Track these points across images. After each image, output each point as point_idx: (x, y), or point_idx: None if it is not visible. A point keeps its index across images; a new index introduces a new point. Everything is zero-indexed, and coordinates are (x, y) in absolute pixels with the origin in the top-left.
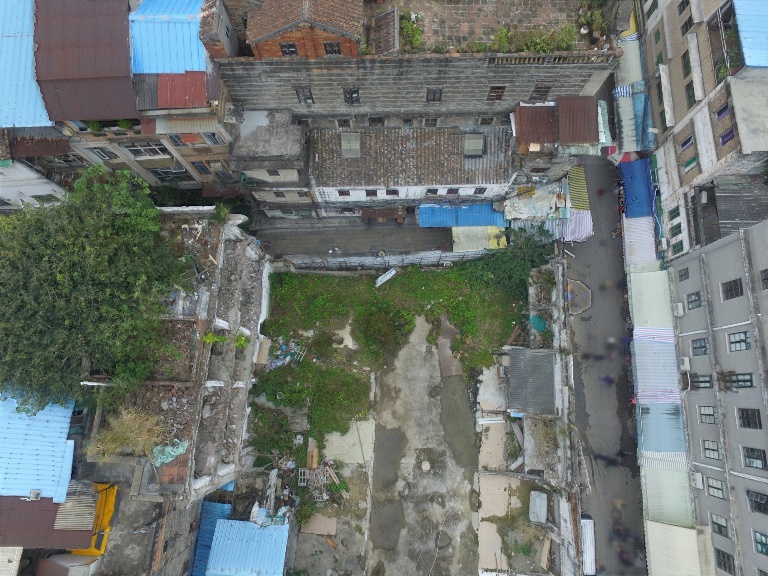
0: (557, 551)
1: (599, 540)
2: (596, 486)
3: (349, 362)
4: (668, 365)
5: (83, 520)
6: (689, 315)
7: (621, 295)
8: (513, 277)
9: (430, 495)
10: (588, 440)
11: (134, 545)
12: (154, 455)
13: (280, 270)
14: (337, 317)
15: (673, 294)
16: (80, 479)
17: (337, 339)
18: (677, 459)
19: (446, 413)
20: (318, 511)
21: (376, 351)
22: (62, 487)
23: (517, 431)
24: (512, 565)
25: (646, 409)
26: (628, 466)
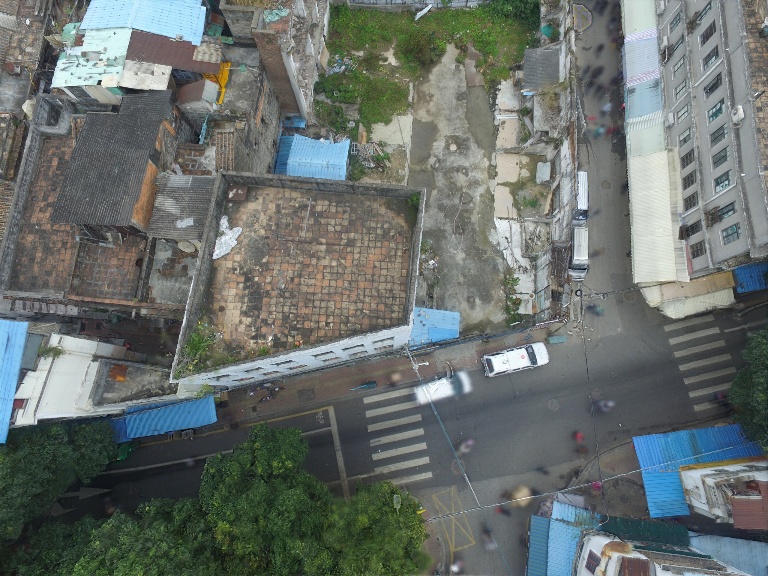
0: (557, 197)
1: (592, 202)
2: (591, 165)
3: (392, 74)
4: (651, 54)
5: (213, 57)
6: (669, 6)
7: (617, 33)
8: (528, 3)
9: (456, 167)
10: (585, 133)
11: (243, 101)
12: (265, 15)
13: (338, 1)
14: (383, 42)
15: (657, 1)
16: (210, 36)
17: (383, 58)
18: (655, 116)
19: (470, 112)
20: (366, 176)
21: (414, 66)
22: (198, 37)
23: (528, 122)
24: (521, 215)
25: (632, 89)
26: (617, 152)
